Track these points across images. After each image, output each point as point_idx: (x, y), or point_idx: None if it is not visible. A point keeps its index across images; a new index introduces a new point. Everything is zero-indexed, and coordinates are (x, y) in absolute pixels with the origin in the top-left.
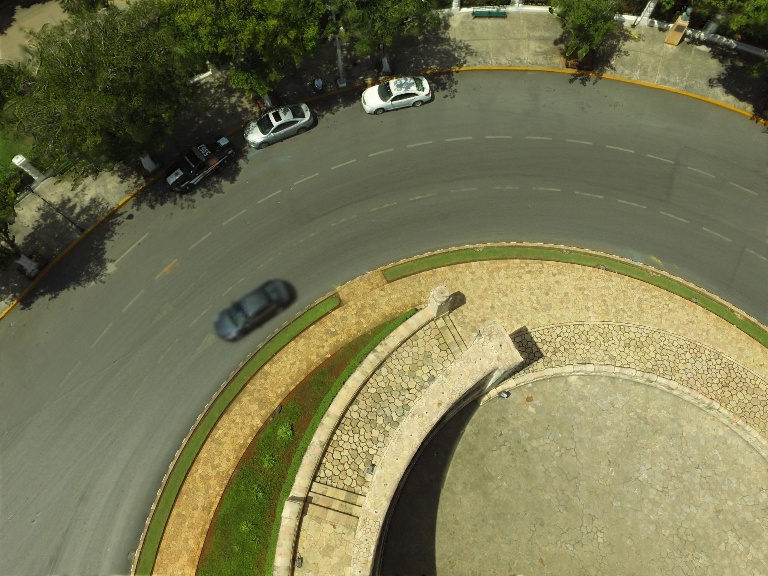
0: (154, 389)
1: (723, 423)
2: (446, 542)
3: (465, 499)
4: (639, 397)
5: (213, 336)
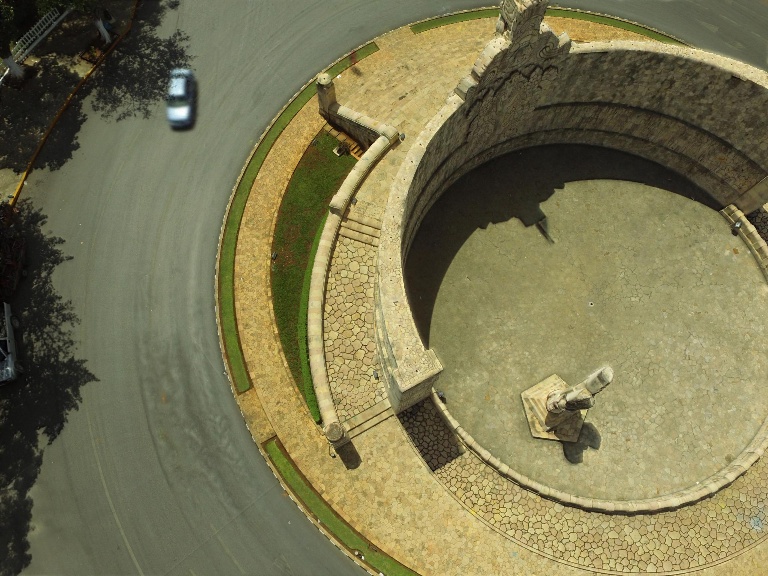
0: (667, 0)
1: (765, 419)
2: (606, 187)
3: (641, 200)
4: (766, 344)
5: (717, 30)
